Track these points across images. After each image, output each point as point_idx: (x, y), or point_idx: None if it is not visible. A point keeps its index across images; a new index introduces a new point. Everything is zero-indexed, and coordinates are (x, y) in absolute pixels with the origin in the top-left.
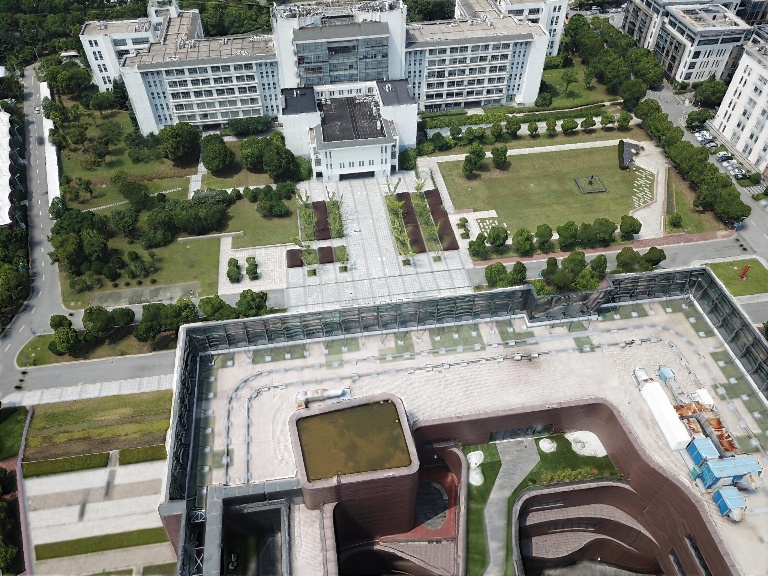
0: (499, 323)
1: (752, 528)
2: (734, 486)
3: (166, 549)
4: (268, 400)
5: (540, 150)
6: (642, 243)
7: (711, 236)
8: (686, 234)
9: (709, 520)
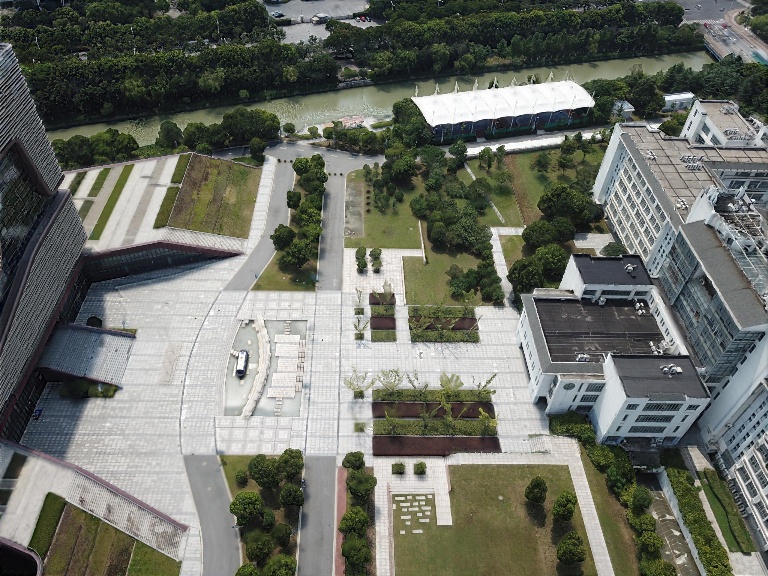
0: None
1: None
2: None
3: (99, 209)
4: None
5: None
6: None
7: None
8: None
9: None
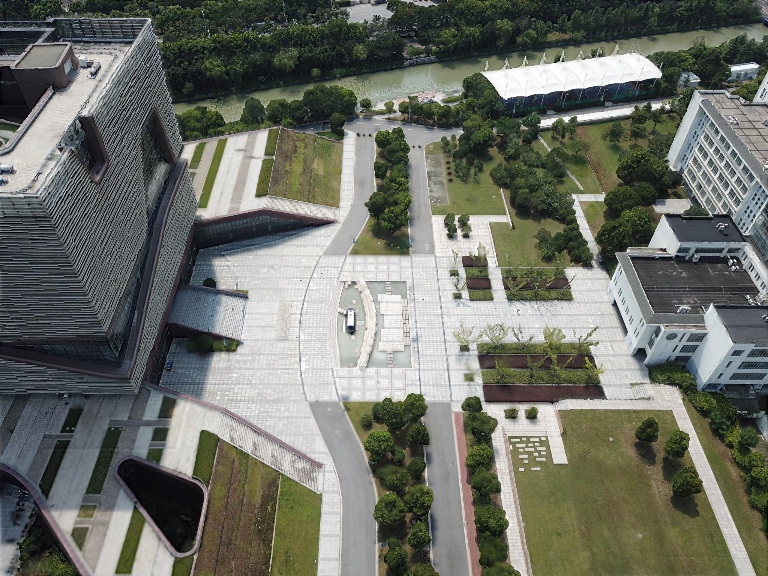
0: None
1: None
2: None
3: (202, 180)
4: (107, 58)
5: None
6: None
7: None
8: None
9: None
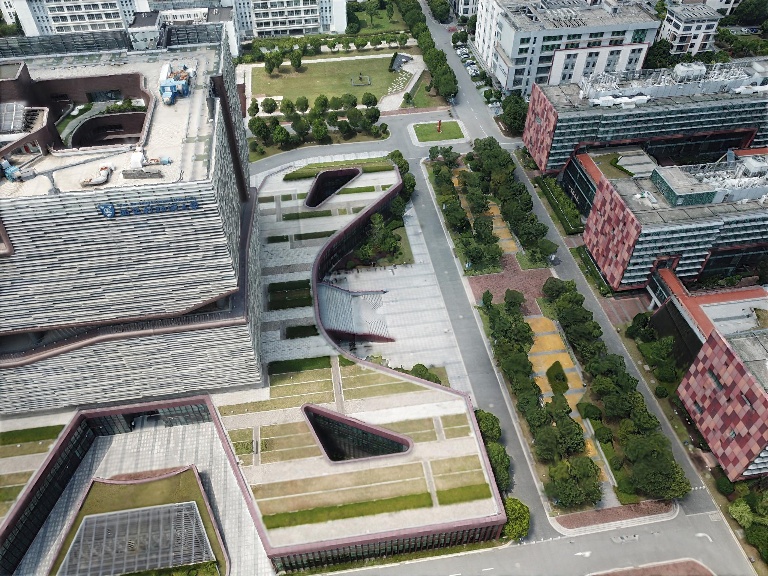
0: (114, 54)
1: (175, 108)
2: (171, 92)
3: None
4: None
5: (333, 60)
6: (380, 113)
7: (432, 109)
8: (415, 108)
9: (152, 102)
